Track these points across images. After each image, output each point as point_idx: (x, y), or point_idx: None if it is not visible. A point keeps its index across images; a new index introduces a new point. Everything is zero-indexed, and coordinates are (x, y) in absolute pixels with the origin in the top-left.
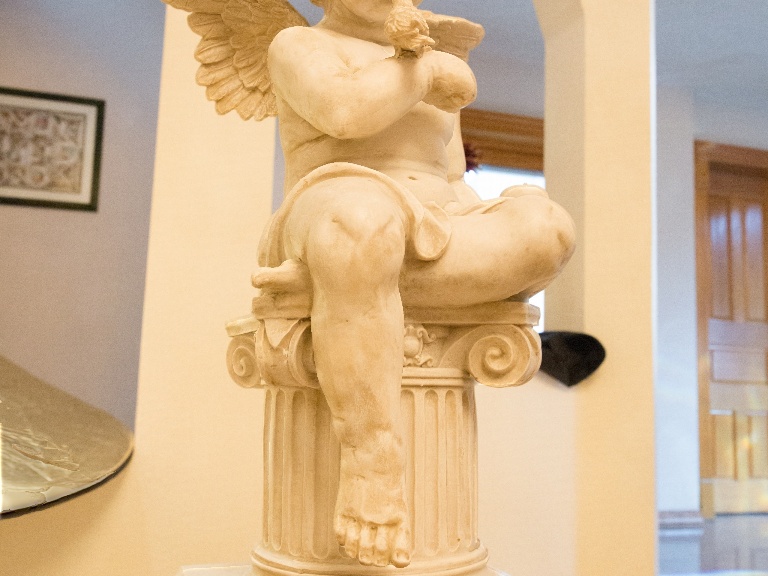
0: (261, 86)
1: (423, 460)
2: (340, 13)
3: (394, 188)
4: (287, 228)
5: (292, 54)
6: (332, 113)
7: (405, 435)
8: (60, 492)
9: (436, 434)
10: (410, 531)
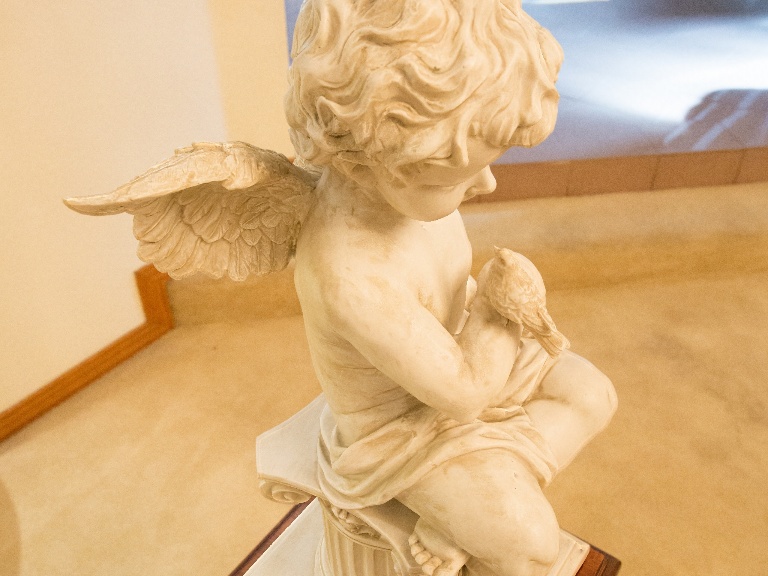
0: (227, 236)
1: None
2: (374, 199)
3: (520, 455)
4: (441, 523)
5: (386, 336)
6: (465, 416)
7: None
8: None
9: None
10: None
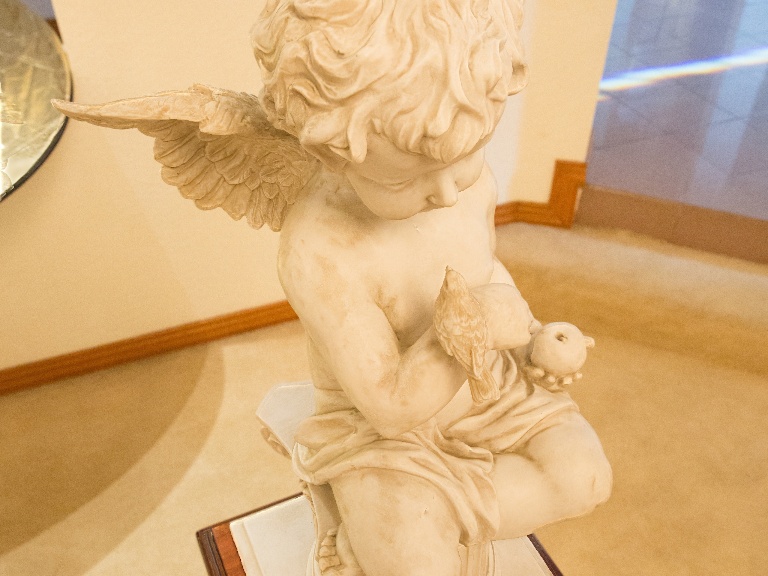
0: (248, 182)
1: None
2: None
3: (447, 496)
4: (344, 525)
5: (318, 318)
6: (380, 429)
7: None
8: (21, 166)
9: (466, 560)
10: None
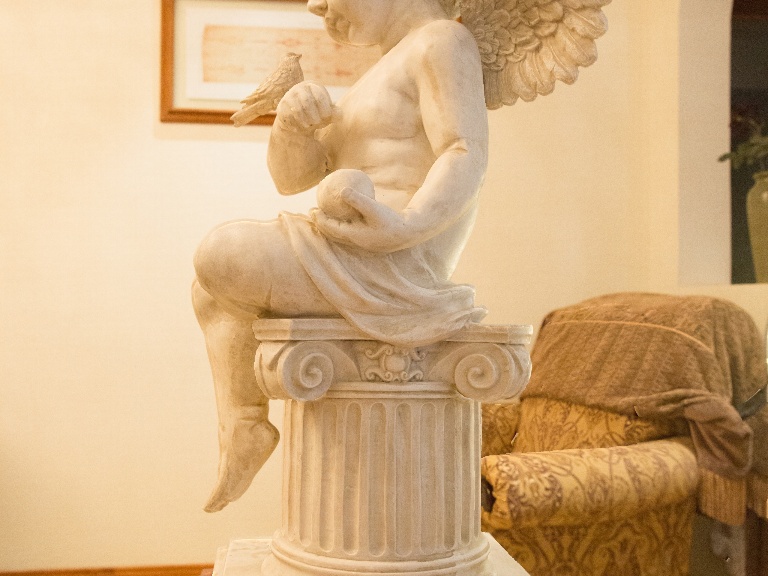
0: None
1: (283, 454)
2: None
3: None
4: None
5: None
6: None
7: (232, 425)
8: None
9: None
10: (215, 491)
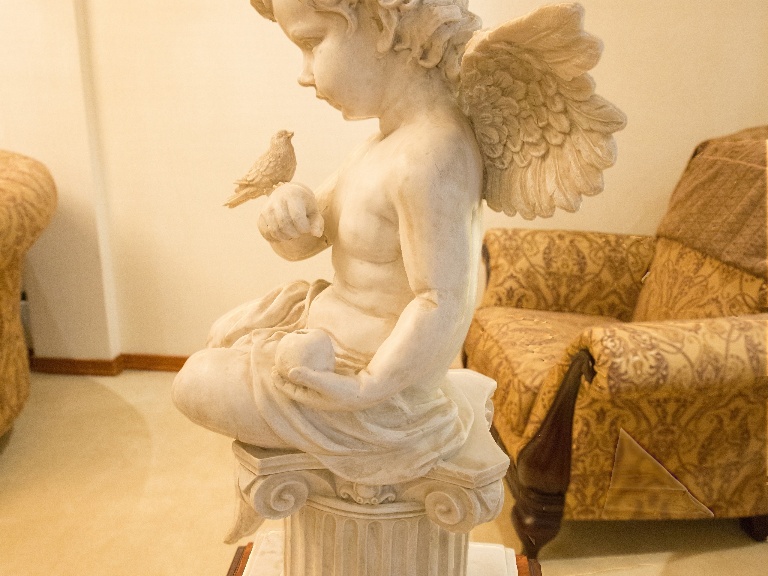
0: None
1: None
2: None
3: None
4: None
5: None
6: None
7: None
8: None
9: None
10: (231, 530)
